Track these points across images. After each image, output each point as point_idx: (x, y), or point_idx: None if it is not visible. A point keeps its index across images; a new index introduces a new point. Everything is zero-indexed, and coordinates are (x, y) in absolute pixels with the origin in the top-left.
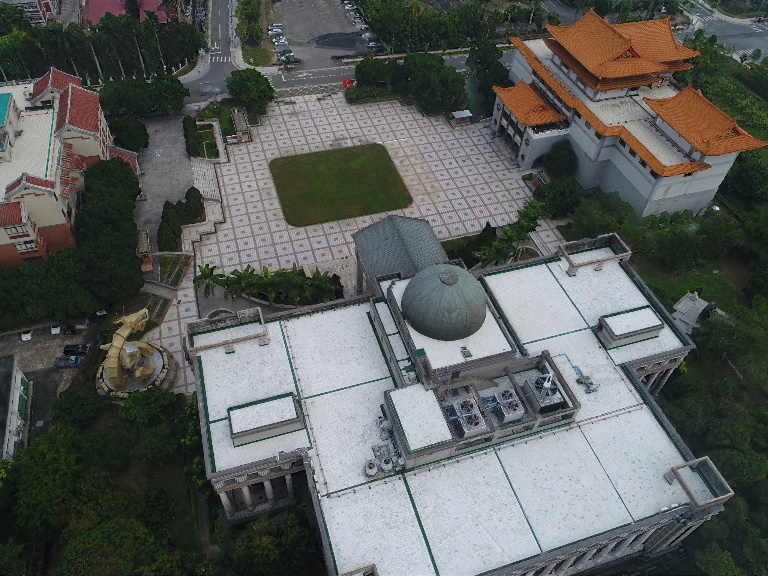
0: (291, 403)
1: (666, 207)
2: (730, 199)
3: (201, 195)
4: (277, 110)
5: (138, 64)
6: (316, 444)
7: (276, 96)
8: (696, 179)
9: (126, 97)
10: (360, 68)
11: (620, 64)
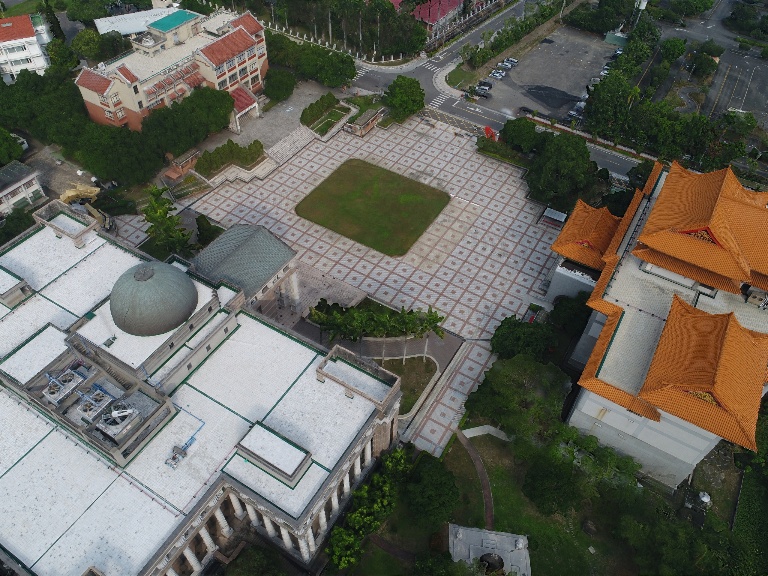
0: (14, 285)
1: (607, 435)
2: (767, 512)
3: (260, 150)
4: (414, 125)
5: (357, 42)
6: None
7: (429, 114)
8: (651, 427)
9: (300, 58)
10: (507, 123)
11: (686, 242)
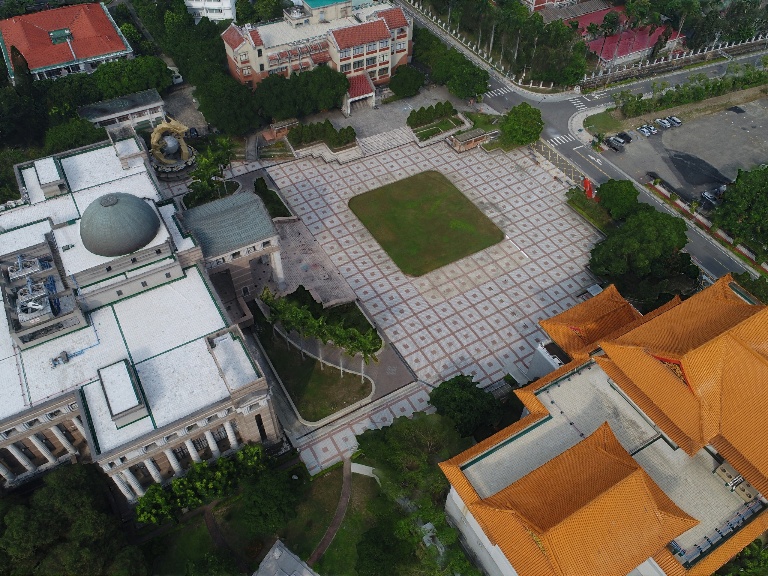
0: (54, 180)
1: (471, 537)
2: None
3: (350, 136)
4: (518, 157)
5: None
6: (32, 206)
7: (541, 150)
8: (499, 550)
9: None
10: (608, 182)
11: (655, 369)
